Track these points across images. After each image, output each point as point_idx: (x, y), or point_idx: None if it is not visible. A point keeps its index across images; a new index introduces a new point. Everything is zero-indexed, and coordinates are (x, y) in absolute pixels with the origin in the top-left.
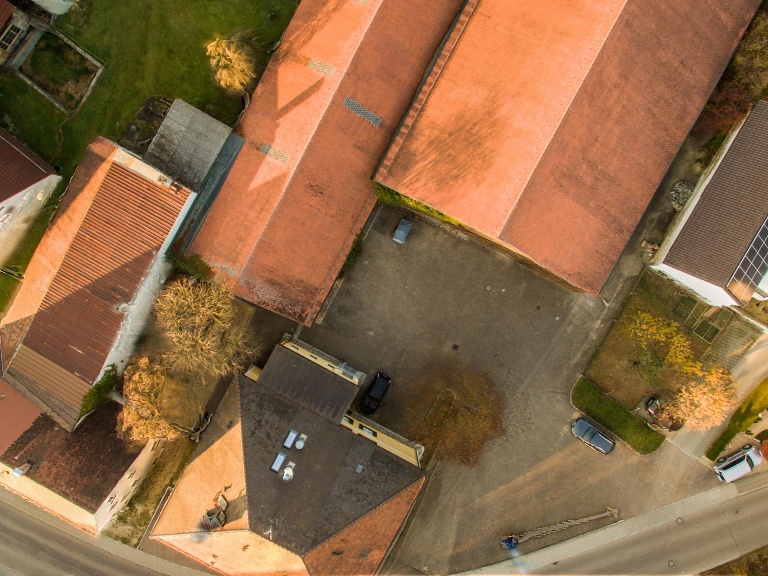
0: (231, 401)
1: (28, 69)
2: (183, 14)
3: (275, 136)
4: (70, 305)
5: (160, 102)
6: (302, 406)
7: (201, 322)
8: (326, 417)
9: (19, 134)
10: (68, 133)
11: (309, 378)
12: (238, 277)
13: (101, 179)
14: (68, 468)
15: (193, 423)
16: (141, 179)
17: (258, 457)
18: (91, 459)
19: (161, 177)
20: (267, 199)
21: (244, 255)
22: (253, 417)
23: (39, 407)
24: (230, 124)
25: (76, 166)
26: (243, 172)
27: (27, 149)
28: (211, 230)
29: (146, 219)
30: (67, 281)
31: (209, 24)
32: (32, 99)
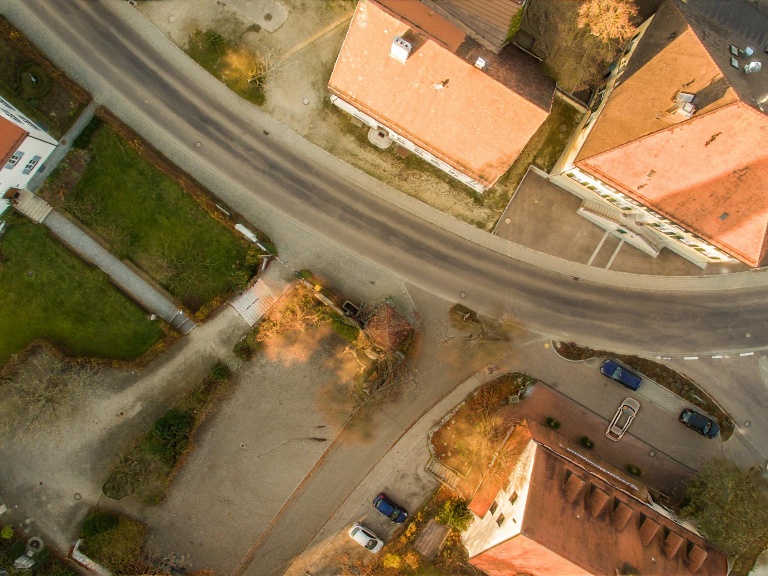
0: (667, 18)
1: None
2: None
3: None
4: None
5: None
6: (729, 31)
7: None
8: (752, 43)
9: None
10: None
11: (734, 5)
12: None
13: None
14: (510, 77)
15: (572, 87)
16: None
17: (717, 55)
18: (523, 77)
19: None
20: None
21: None
22: (697, 27)
23: (462, 30)
24: None
25: None
26: None
27: None
28: None
29: None
30: None
31: None
32: None
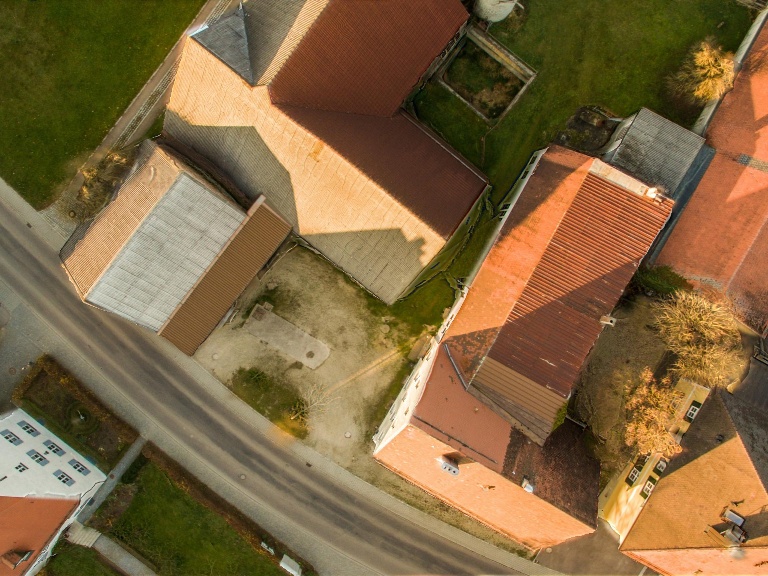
0: (714, 414)
1: (446, 76)
2: (626, 22)
3: (756, 147)
4: (542, 317)
5: (592, 111)
6: None
7: (710, 335)
8: None
9: (451, 143)
10: (489, 142)
11: None
12: (726, 289)
13: (575, 190)
14: (556, 483)
15: None
16: (620, 190)
17: (767, 472)
18: (569, 473)
19: (647, 188)
20: (754, 211)
21: (731, 267)
22: (746, 431)
23: (507, 421)
24: (701, 134)
25: (495, 175)
26: (717, 183)
27: (463, 158)
28: (682, 241)
29: (626, 230)
30: (538, 293)
31: (654, 33)
32: (454, 107)
